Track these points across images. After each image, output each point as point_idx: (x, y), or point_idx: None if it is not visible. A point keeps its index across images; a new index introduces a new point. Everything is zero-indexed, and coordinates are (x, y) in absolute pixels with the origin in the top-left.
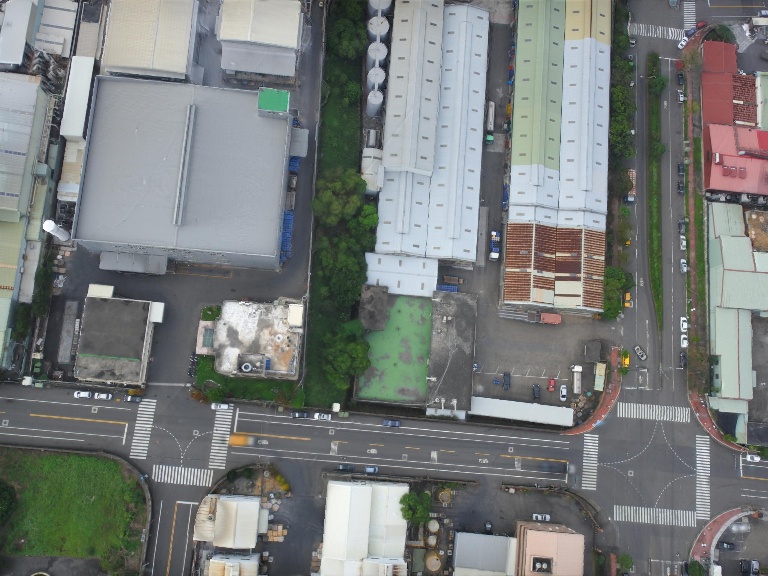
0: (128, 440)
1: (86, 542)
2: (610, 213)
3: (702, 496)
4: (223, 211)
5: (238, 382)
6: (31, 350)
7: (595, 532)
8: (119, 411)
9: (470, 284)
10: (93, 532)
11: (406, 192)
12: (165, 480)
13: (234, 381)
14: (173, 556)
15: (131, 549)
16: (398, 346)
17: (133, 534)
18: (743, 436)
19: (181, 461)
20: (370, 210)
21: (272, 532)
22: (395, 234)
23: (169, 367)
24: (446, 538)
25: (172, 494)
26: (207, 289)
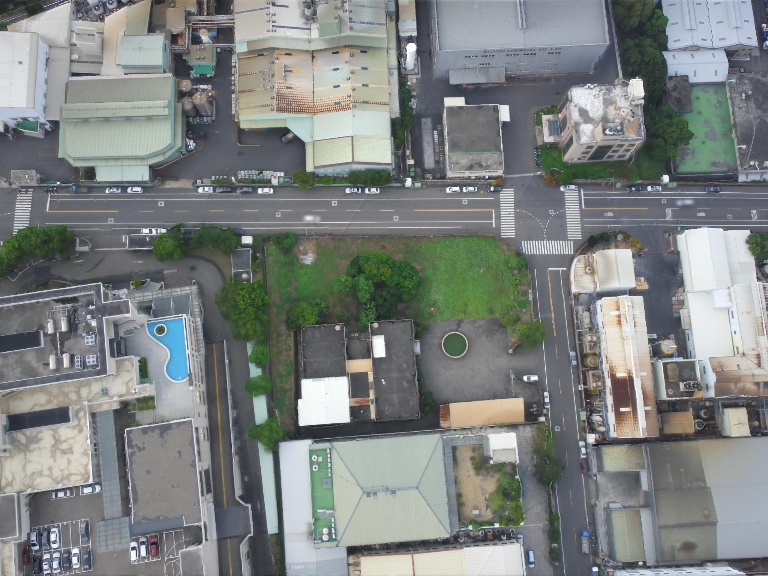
0: (497, 223)
1: (484, 305)
2: None
3: None
4: (548, 20)
5: (578, 167)
6: (406, 157)
7: None
8: (485, 201)
9: (750, 72)
10: (488, 296)
11: None
12: (534, 252)
13: (574, 167)
14: (555, 312)
15: (522, 307)
16: (702, 127)
17: (522, 294)
18: None
19: (544, 236)
20: (661, 12)
21: (638, 282)
22: (684, 31)
23: (518, 161)
24: None
25: (543, 263)
26: (535, 95)
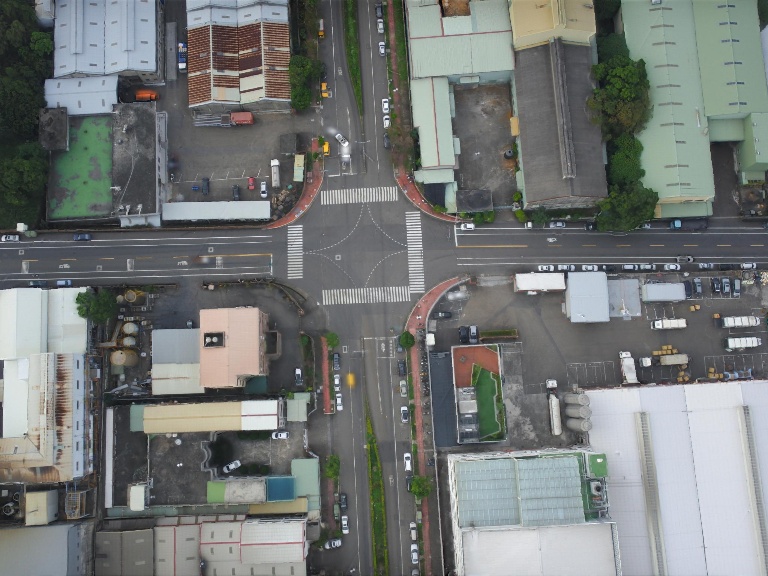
0: None
1: None
2: (302, 8)
3: (415, 270)
4: None
5: None
6: None
7: (299, 316)
8: None
9: (163, 99)
10: None
11: (77, 14)
12: None
13: None
14: None
15: None
16: (87, 165)
17: None
18: (453, 205)
19: None
20: (39, 35)
21: None
22: (70, 56)
23: None
24: (149, 341)
25: None
26: None
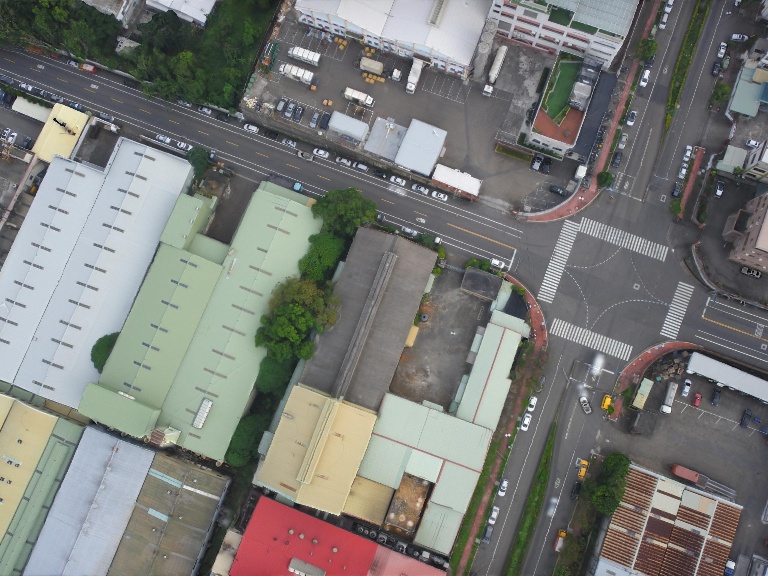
0: None
1: None
2: None
3: (566, 243)
4: None
5: None
6: None
7: None
8: None
9: (761, 538)
10: None
11: None
12: None
13: None
14: None
15: None
16: None
17: None
18: (504, 288)
19: None
20: None
21: None
22: None
23: None
24: None
25: None
26: None
